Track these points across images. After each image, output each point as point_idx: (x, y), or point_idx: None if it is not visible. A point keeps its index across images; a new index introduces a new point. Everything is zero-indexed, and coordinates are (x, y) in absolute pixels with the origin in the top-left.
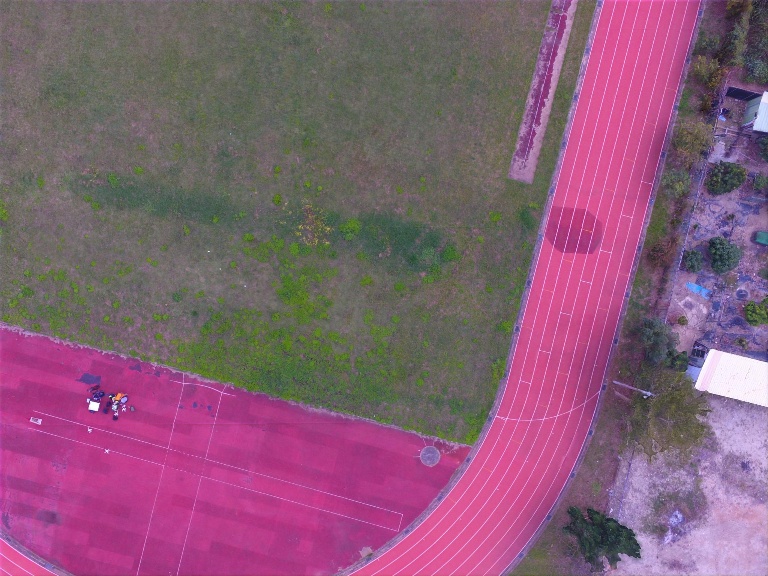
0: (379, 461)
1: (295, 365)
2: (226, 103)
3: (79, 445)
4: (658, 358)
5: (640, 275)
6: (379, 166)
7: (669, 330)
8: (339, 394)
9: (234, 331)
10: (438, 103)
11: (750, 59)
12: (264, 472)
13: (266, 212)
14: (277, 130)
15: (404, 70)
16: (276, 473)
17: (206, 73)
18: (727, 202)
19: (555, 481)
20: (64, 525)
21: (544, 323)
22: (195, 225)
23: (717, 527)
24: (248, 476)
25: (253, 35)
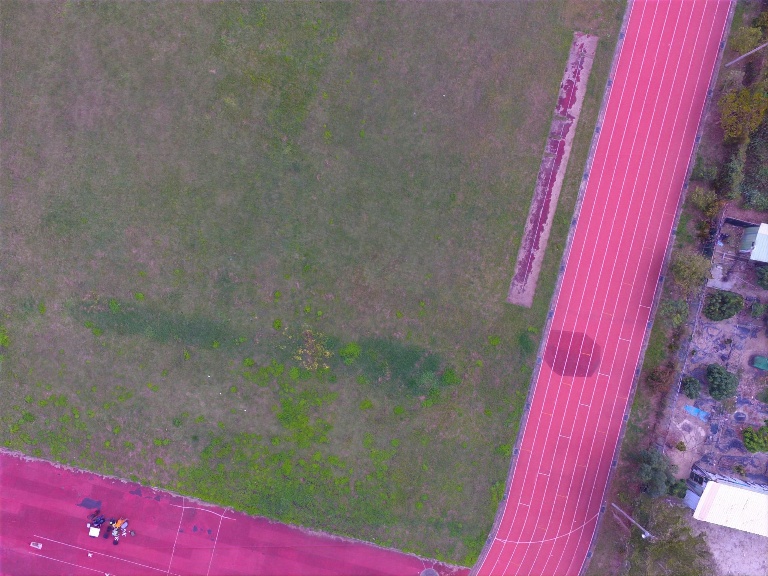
0: None
1: (295, 489)
2: (226, 229)
3: (79, 569)
4: (656, 494)
5: (638, 398)
6: (379, 291)
7: (667, 464)
8: (339, 517)
9: (234, 455)
10: (437, 228)
11: (747, 188)
12: None
13: (266, 337)
14: (277, 255)
15: (403, 196)
16: None
17: (207, 200)
18: (725, 325)
19: None
20: None
21: (543, 446)
22: (195, 350)
23: None
24: None
25: (253, 162)
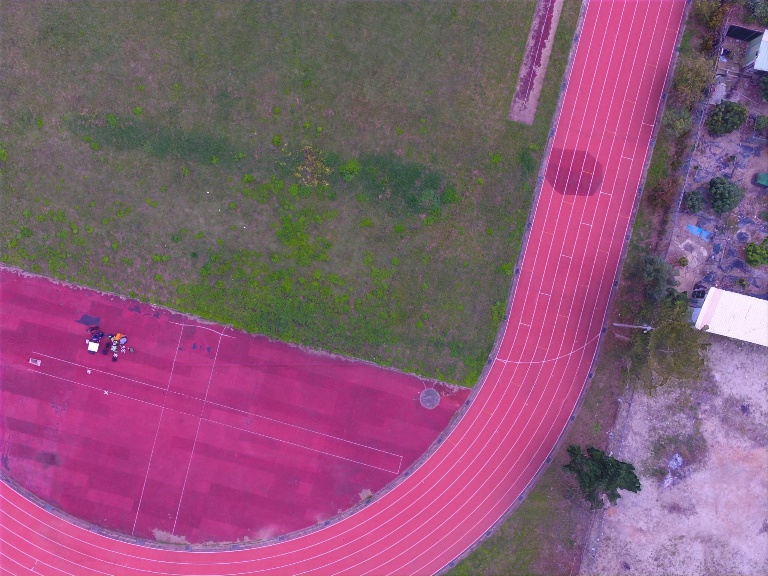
0: (379, 403)
1: (295, 307)
2: (225, 43)
3: (78, 386)
4: (658, 294)
5: (640, 217)
6: (379, 107)
7: (669, 267)
8: (339, 336)
9: (233, 272)
10: (438, 44)
11: None
12: (264, 414)
13: (266, 153)
14: (277, 71)
15: (404, 10)
16: (276, 415)
17: (205, 13)
18: (728, 144)
19: (555, 424)
20: (63, 467)
21: (544, 265)
22: (194, 166)
23: (717, 470)
24: (248, 418)
25: None
